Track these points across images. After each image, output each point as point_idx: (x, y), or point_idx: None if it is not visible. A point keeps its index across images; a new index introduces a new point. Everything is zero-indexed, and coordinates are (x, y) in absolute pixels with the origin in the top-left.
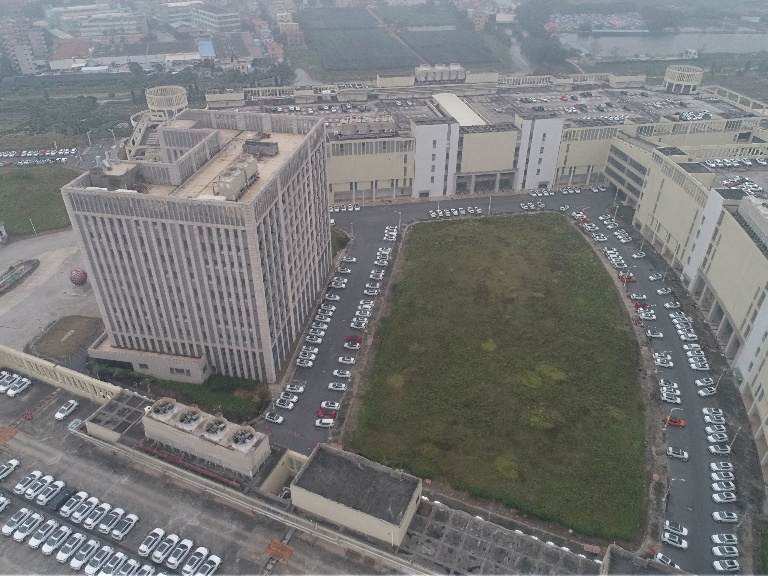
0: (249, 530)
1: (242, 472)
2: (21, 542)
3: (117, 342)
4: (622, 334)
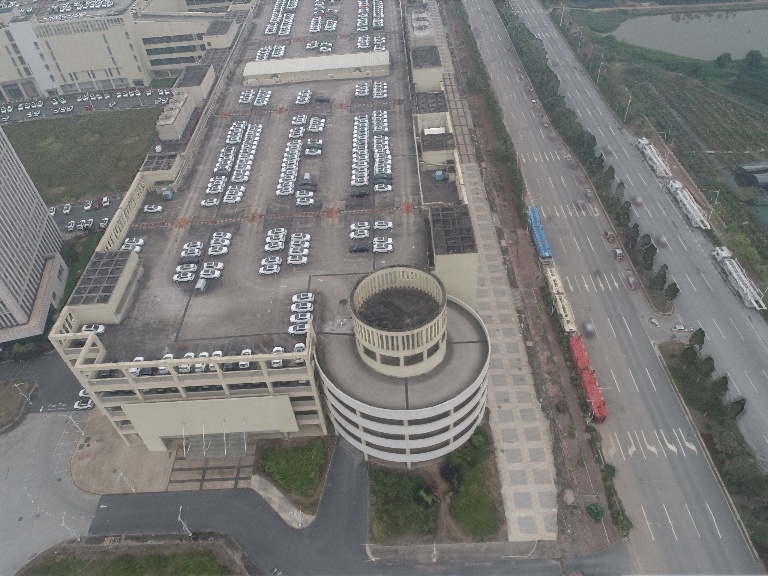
0: (216, 125)
1: (194, 107)
2: (250, 174)
3: (25, 313)
4: (5, 127)
